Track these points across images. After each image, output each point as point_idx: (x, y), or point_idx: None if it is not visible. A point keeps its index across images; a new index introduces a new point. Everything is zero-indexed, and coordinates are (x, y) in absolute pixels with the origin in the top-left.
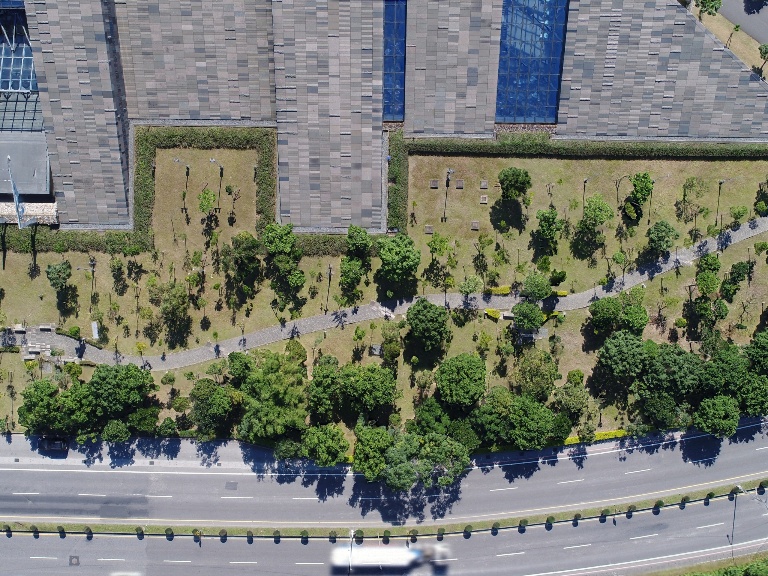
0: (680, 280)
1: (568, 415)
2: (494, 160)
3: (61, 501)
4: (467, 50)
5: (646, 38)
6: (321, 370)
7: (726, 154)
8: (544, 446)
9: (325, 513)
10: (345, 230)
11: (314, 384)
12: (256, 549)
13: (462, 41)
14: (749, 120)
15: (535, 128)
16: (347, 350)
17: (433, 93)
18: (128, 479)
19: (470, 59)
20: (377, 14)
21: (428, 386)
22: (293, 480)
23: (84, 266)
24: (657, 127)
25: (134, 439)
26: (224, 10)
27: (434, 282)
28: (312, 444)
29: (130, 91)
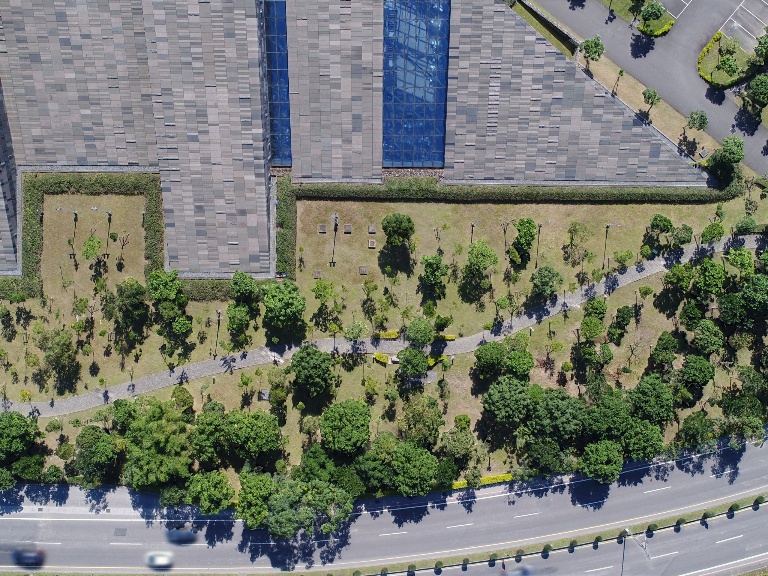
0: (568, 323)
1: (453, 460)
2: (382, 205)
3: None
4: (350, 97)
5: (527, 85)
6: (205, 417)
7: (612, 198)
8: (428, 492)
9: (214, 559)
10: None
11: (197, 431)
12: None
13: (344, 88)
14: (634, 164)
15: (422, 173)
16: (236, 395)
17: (319, 139)
18: (17, 526)
19: (354, 106)
20: (253, 64)
21: (314, 432)
22: (182, 526)
23: None
24: (544, 171)
25: (23, 486)
26: (105, 58)
27: (323, 327)
28: (194, 492)
29: (16, 138)
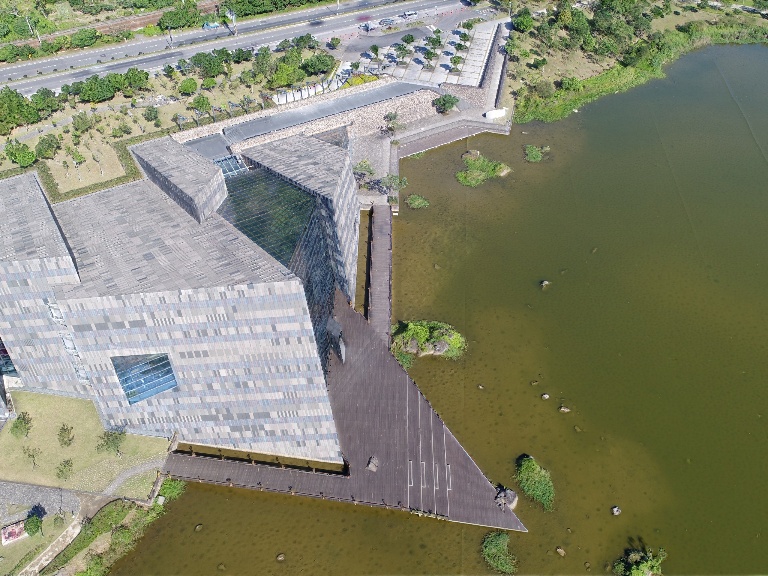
0: None
1: None
2: None
3: (120, 67)
4: None
5: None
6: None
7: None
8: None
9: None
10: None
11: None
12: (7, 79)
13: None
14: None
15: None
16: None
17: None
18: None
19: None
20: None
21: None
22: None
23: (148, 129)
24: None
25: None
26: None
27: None
28: None
29: None
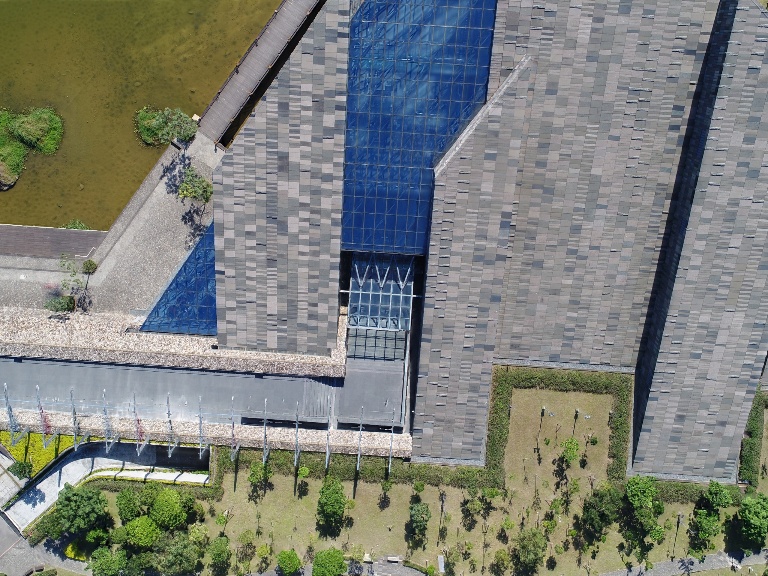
0: None
1: None
2: None
3: None
4: None
5: None
6: None
7: None
8: None
9: None
10: (695, 478)
11: None
12: None
13: None
14: None
15: None
16: None
17: None
18: None
19: None
20: None
21: None
22: None
23: (433, 499)
24: None
25: None
26: (608, 269)
27: None
28: None
29: None
